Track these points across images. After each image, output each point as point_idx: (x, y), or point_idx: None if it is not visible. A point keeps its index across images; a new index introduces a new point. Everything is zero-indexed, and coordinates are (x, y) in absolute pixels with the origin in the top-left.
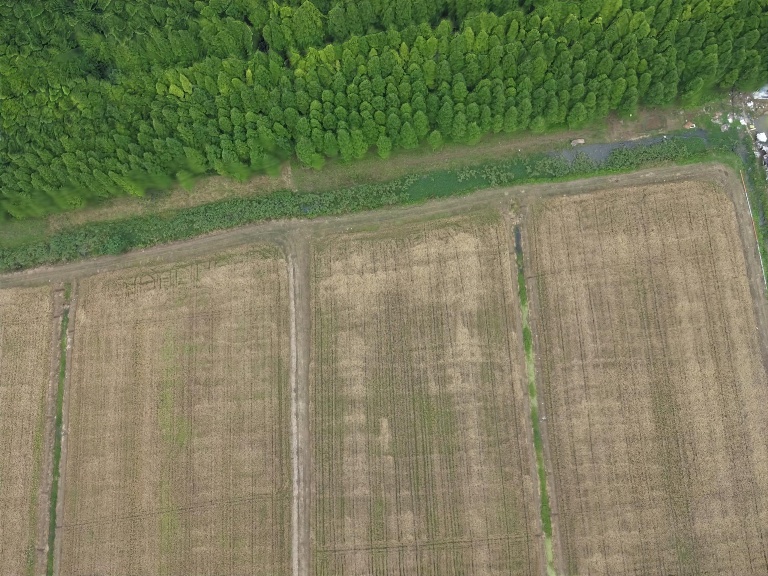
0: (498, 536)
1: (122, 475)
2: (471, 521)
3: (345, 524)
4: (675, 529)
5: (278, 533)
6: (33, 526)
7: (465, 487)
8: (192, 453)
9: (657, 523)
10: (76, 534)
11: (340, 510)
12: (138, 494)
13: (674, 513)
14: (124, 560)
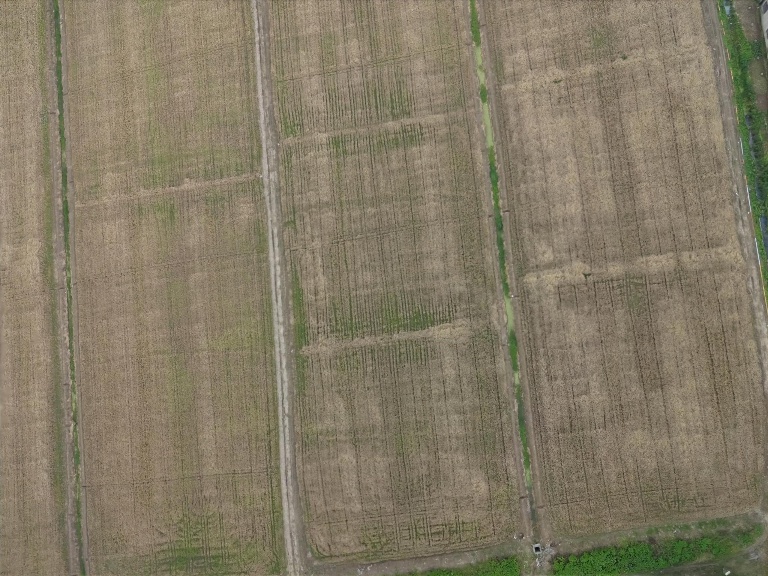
0: (433, 48)
1: (112, 46)
2: (409, 39)
3: (300, 57)
4: (591, 20)
5: (244, 72)
6: (45, 95)
7: (403, 13)
8: (168, 20)
9: (575, 18)
10: (79, 96)
11: (295, 47)
12: (126, 59)
13: (591, 7)
14: (120, 110)
